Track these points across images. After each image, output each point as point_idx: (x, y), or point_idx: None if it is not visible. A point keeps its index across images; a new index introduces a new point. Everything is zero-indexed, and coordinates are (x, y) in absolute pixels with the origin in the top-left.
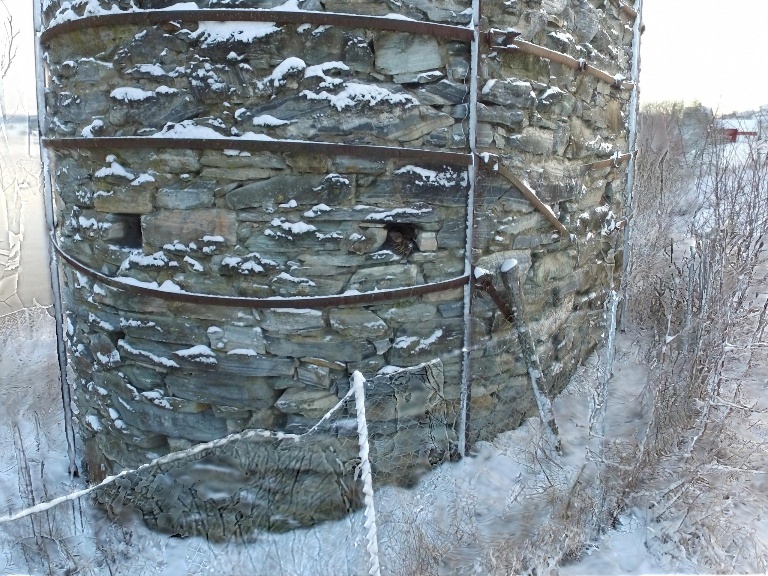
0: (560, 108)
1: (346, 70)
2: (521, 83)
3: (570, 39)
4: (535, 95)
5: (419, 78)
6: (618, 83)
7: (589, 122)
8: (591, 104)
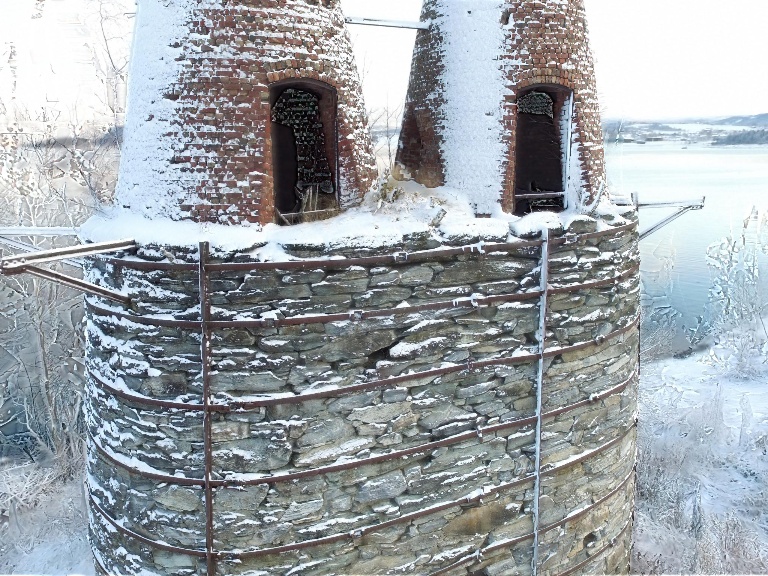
0: (325, 568)
1: (141, 562)
2: (255, 574)
3: (331, 524)
4: (277, 575)
5: (179, 572)
6: (471, 501)
7: (396, 554)
8: (403, 538)
